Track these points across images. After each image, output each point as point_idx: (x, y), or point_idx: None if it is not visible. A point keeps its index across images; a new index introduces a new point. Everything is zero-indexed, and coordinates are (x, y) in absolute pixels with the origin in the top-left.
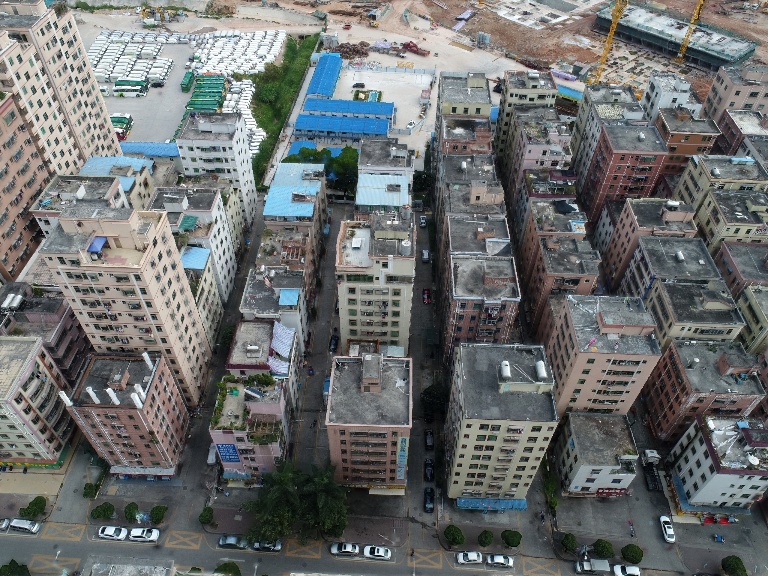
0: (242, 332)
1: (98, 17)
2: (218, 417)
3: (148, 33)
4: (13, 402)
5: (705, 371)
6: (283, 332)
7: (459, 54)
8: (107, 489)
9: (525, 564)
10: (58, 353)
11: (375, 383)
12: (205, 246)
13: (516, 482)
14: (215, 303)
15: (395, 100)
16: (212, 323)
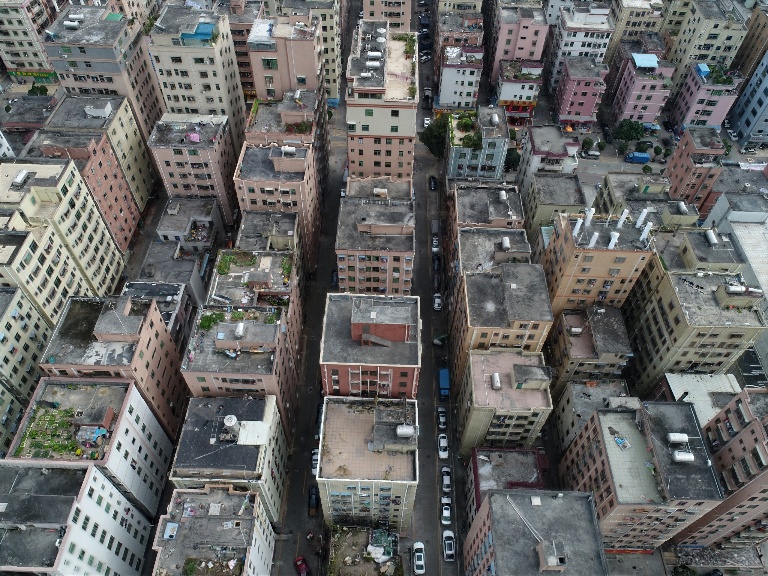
0: (166, 3)
1: None
2: (148, 32)
3: None
4: (25, 9)
5: (453, 25)
6: (193, 5)
7: None
8: None
9: (335, 132)
10: (50, 3)
11: (238, 5)
12: None
13: (328, 78)
14: (153, 4)
15: None
16: (151, 15)
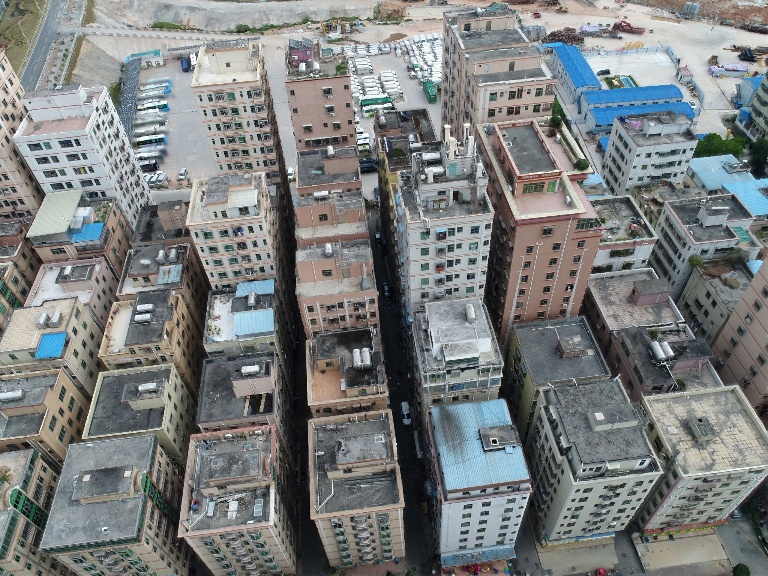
0: None
1: (272, 38)
2: None
3: (343, 47)
4: None
5: None
6: None
7: (672, 28)
8: (767, 542)
9: None
10: None
11: None
12: (750, 258)
13: None
14: None
15: (652, 82)
16: None
